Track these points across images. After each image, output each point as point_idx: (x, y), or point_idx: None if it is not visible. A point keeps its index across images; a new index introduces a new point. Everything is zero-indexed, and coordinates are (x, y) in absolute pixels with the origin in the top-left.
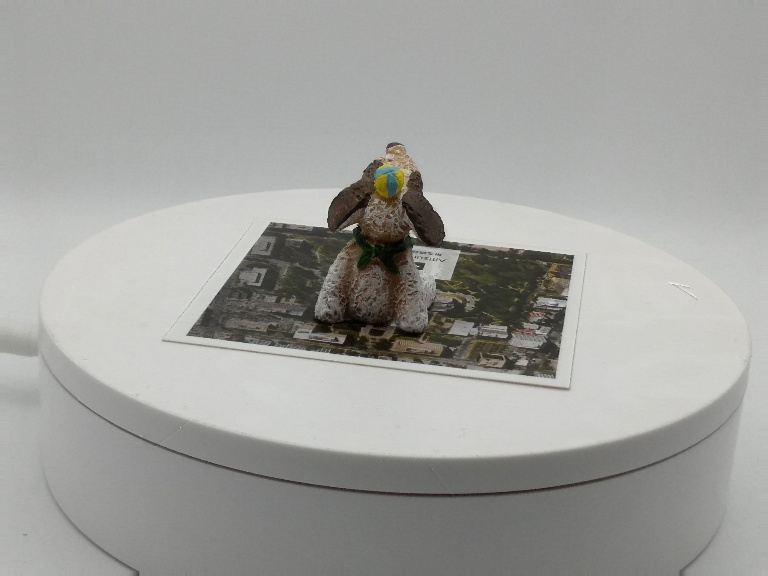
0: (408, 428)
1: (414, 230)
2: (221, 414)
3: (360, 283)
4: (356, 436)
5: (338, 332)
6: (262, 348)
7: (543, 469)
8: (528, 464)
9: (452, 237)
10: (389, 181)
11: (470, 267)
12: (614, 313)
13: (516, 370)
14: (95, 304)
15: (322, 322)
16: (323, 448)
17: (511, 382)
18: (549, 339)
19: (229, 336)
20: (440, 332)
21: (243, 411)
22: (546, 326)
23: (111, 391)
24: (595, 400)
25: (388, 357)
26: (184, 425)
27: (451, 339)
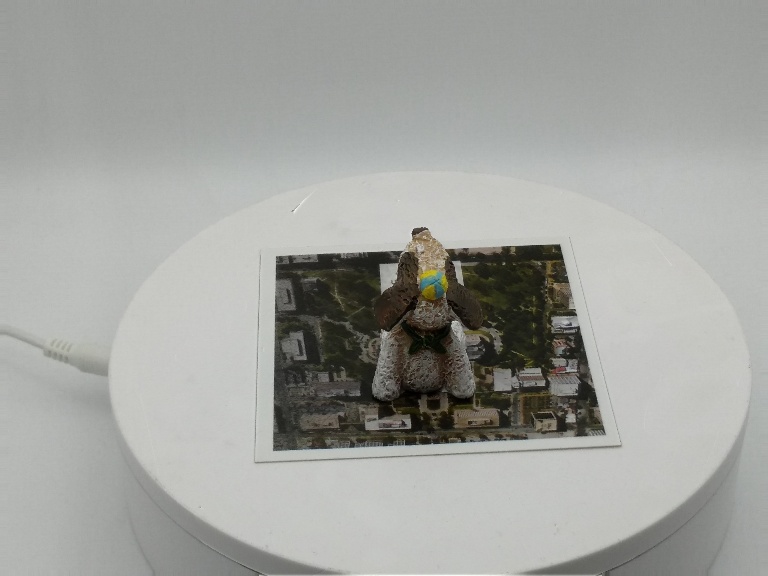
0: (509, 534)
1: (461, 322)
2: (348, 555)
3: (412, 365)
4: (471, 556)
5: (401, 412)
6: (345, 452)
7: (629, 548)
8: (618, 550)
9: (445, 242)
10: (437, 291)
11: (478, 285)
12: (621, 323)
13: (570, 431)
14: (173, 423)
15: (382, 402)
16: None
17: (571, 448)
18: (581, 378)
19: (311, 442)
20: (487, 391)
21: (365, 546)
22: (572, 359)
23: (240, 544)
24: (647, 455)
25: (457, 439)
26: (320, 573)
27: (500, 399)
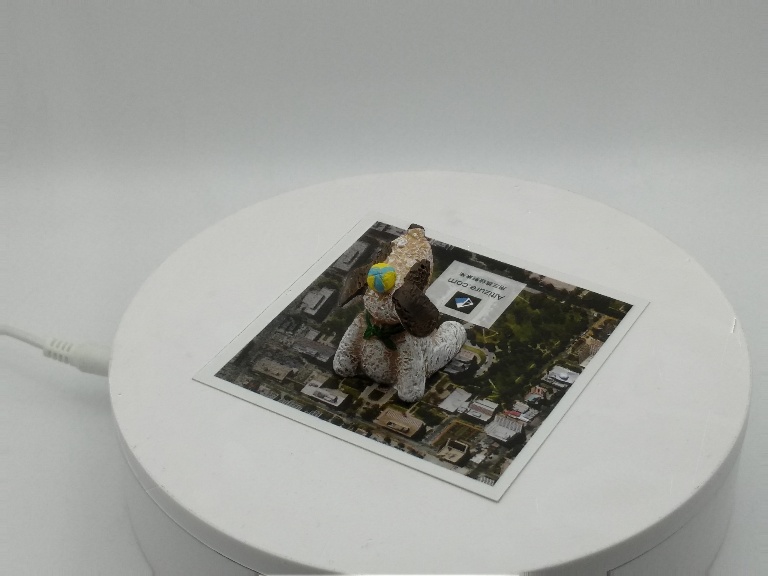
0: (326, 528)
1: None
2: (186, 483)
3: (367, 350)
4: (277, 531)
5: (343, 390)
6: (266, 402)
7: None
8: None
9: (531, 263)
10: (376, 283)
11: (519, 311)
12: (615, 398)
13: (465, 468)
14: (166, 321)
15: (336, 374)
16: (242, 540)
17: (451, 483)
18: (525, 429)
19: (248, 382)
20: (432, 403)
21: (205, 482)
22: (535, 409)
23: (121, 436)
24: (512, 520)
25: (365, 431)
26: (156, 487)
27: (435, 415)
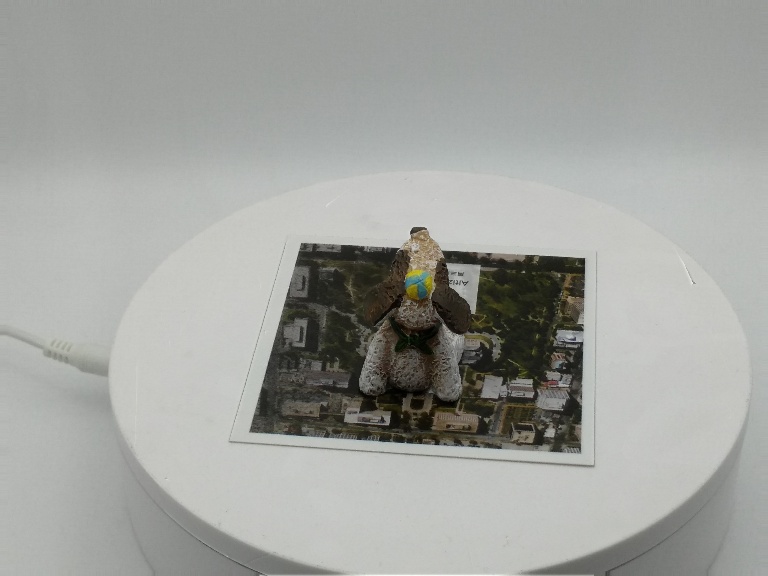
0: (459, 540)
1: (445, 324)
2: (296, 542)
3: (398, 362)
4: (415, 557)
5: (383, 408)
6: (319, 442)
7: (578, 569)
8: (565, 569)
9: (471, 245)
10: (419, 291)
11: (491, 291)
12: (627, 344)
13: (545, 445)
14: (161, 394)
15: (367, 396)
16: None
17: (542, 462)
18: (571, 394)
19: (287, 428)
20: (473, 396)
21: (314, 535)
22: (567, 374)
23: (196, 519)
24: (618, 478)
25: (431, 440)
26: (265, 556)
27: (484, 406)
